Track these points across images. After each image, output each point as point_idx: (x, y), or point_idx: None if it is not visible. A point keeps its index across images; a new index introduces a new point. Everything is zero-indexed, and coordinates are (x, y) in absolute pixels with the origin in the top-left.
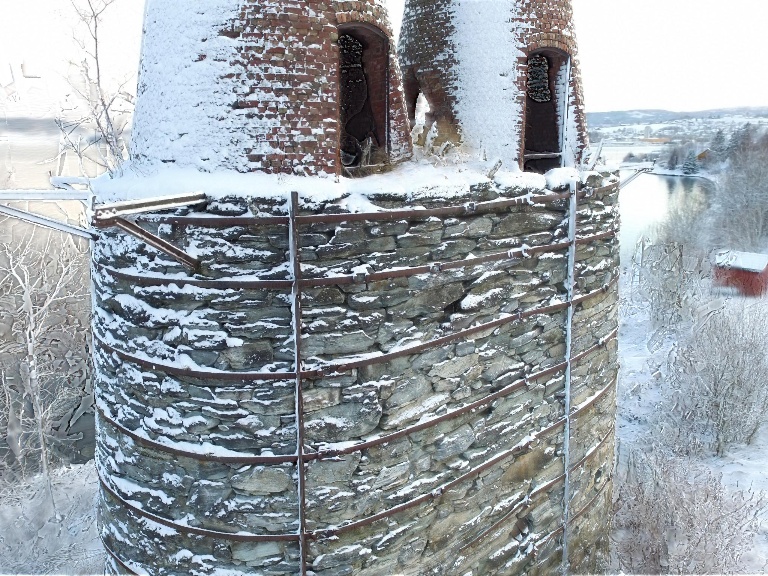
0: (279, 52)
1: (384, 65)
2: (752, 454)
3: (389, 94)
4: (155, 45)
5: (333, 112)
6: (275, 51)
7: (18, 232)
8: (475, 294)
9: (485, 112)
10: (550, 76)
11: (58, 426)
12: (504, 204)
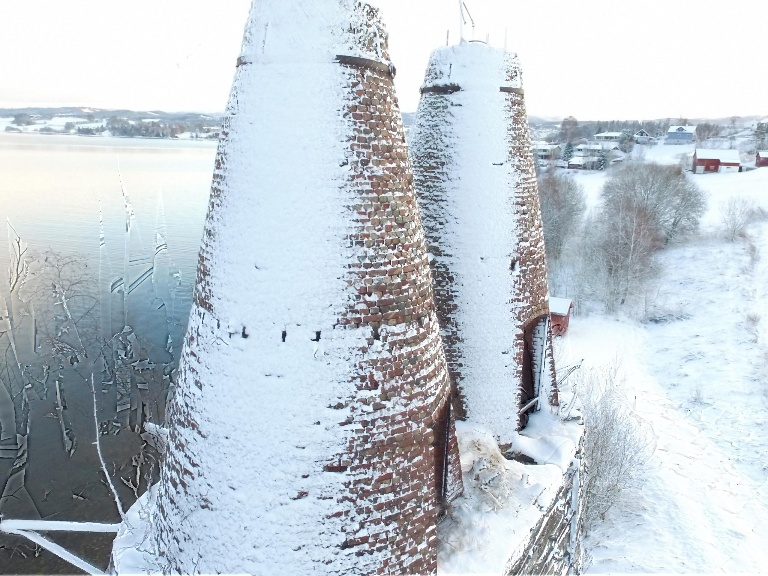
0: (387, 478)
1: (444, 416)
2: (610, 532)
3: (448, 443)
4: (229, 466)
5: (433, 518)
6: (383, 478)
7: None
8: None
9: (489, 389)
10: (528, 329)
11: None
12: (546, 524)
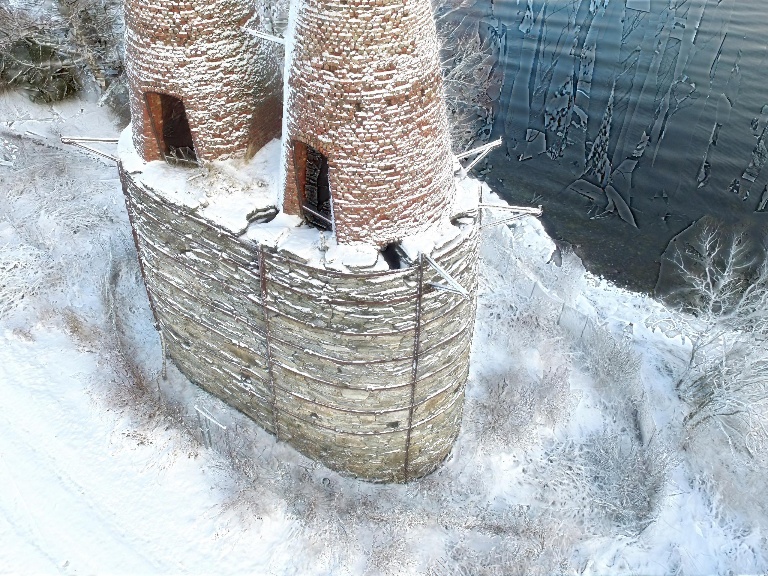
0: None
1: None
2: None
3: None
4: None
5: None
6: None
7: (458, 17)
8: (195, 254)
9: None
10: None
11: (467, 158)
12: None
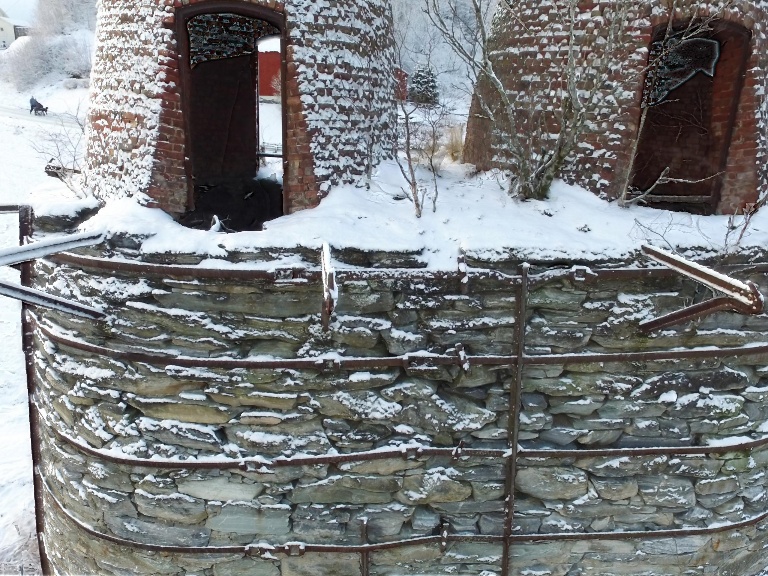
0: None
1: None
2: None
3: None
4: None
5: None
6: None
7: None
8: None
9: None
10: None
11: None
12: None
